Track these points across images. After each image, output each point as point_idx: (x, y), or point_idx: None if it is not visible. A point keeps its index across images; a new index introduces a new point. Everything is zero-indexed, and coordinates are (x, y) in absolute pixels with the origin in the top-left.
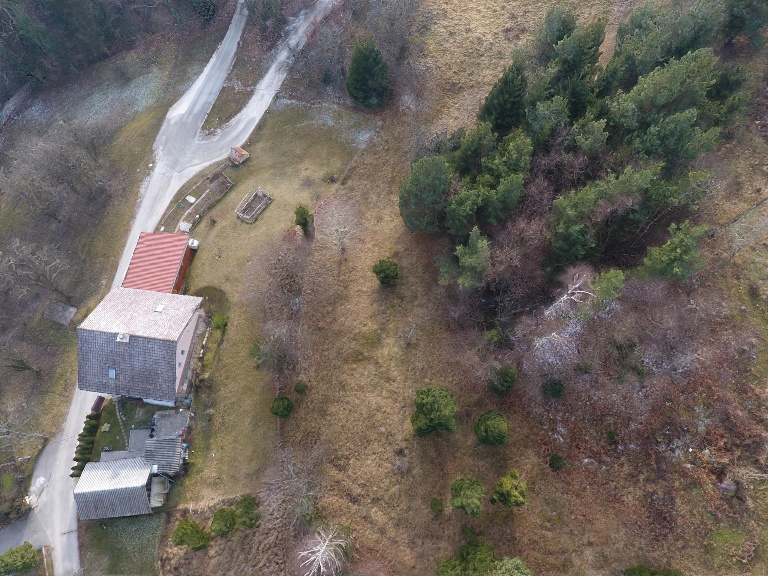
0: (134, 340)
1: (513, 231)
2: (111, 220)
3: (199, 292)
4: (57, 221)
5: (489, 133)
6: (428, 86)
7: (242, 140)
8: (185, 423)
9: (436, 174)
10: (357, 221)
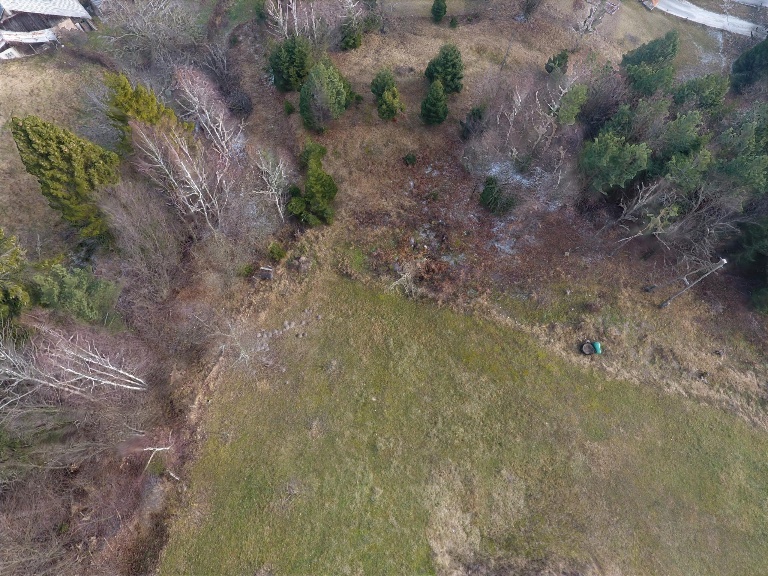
0: None
1: None
2: None
3: None
4: None
5: None
6: None
7: None
8: None
9: None
10: None
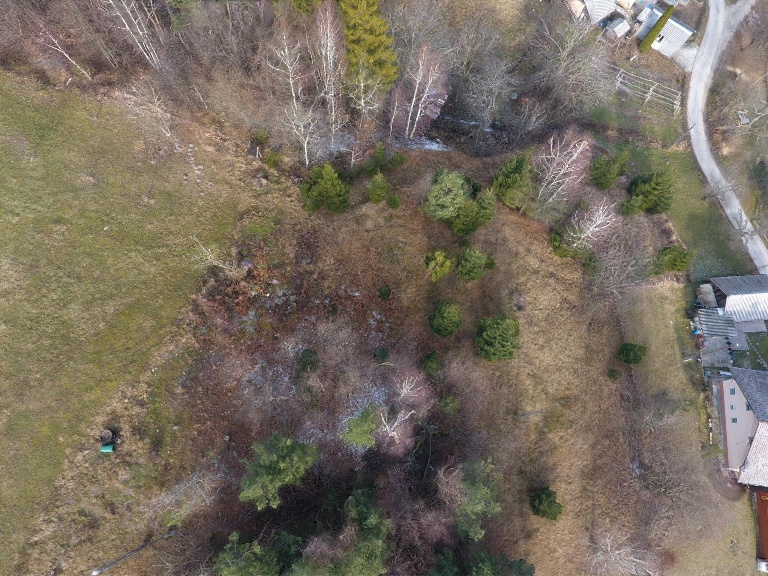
0: None
1: None
2: None
3: (737, 496)
4: None
5: None
6: None
7: None
8: None
9: None
10: None
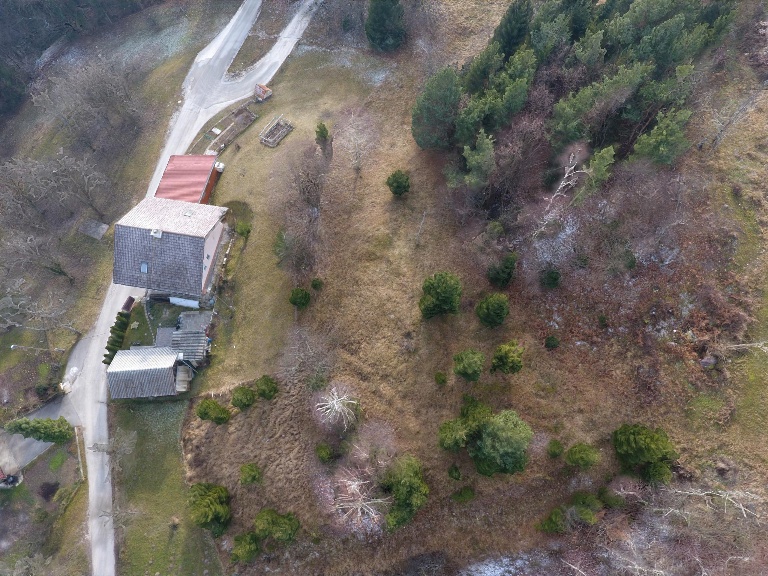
0: (166, 236)
1: (516, 129)
2: (142, 149)
3: None
4: (91, 150)
5: (497, 54)
6: (441, 30)
7: (265, 81)
8: (208, 322)
9: (447, 86)
10: (372, 145)
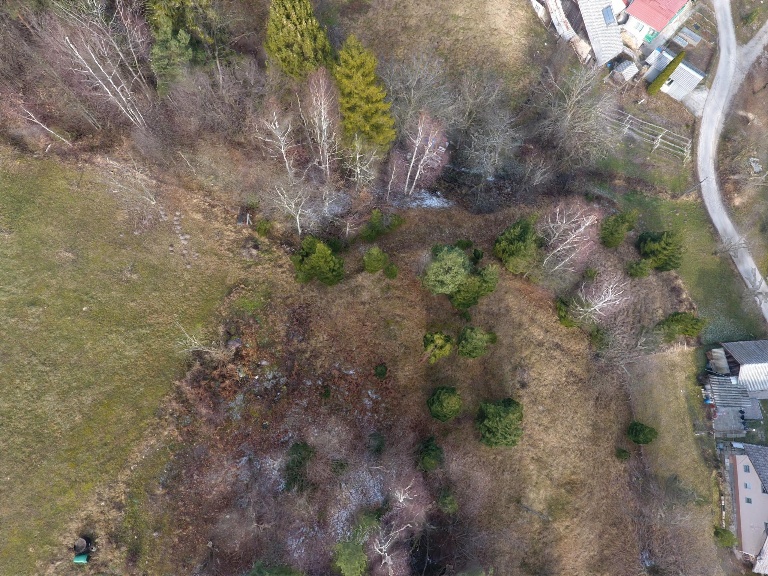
0: None
1: None
2: None
3: None
4: None
5: None
6: None
7: None
8: None
9: None
10: None
